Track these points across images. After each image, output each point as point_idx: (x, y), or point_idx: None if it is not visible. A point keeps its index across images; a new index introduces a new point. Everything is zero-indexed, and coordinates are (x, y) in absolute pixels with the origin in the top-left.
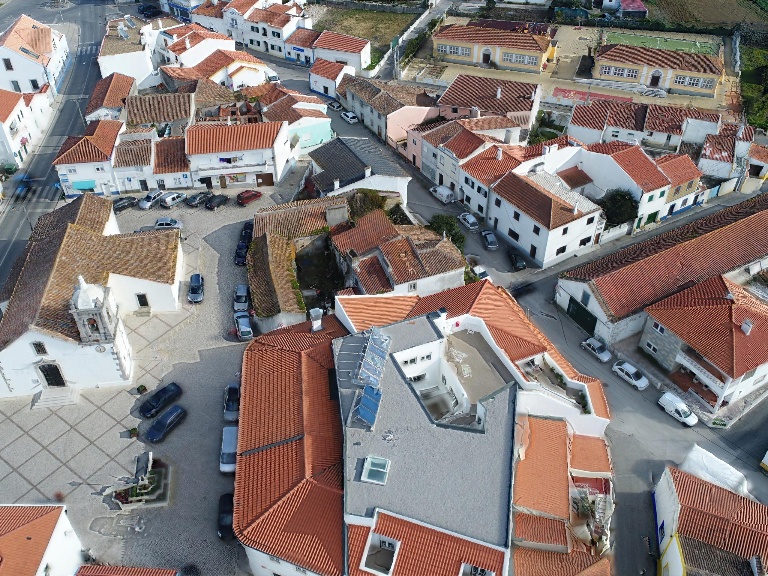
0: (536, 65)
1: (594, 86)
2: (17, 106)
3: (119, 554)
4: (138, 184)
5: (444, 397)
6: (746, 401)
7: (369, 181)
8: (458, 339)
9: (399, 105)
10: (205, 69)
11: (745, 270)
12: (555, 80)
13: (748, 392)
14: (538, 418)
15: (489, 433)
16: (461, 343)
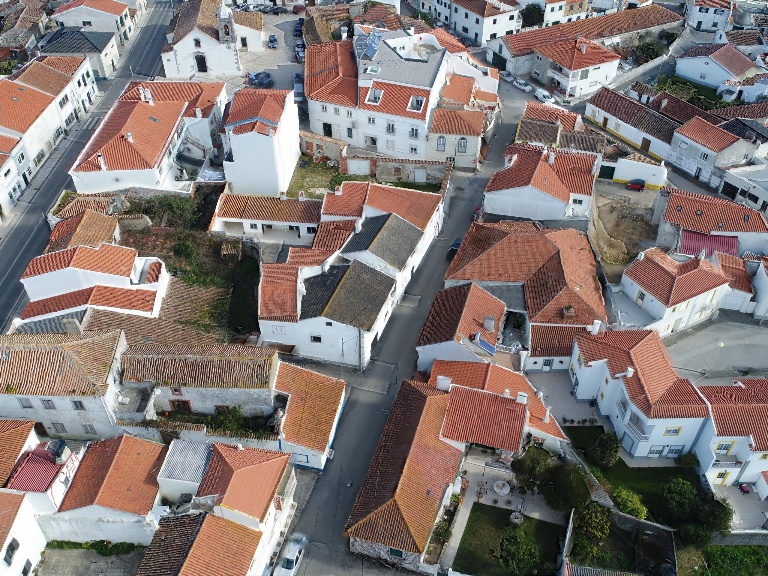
0: None
1: None
2: None
3: None
4: (231, 0)
5: None
6: (586, 96)
7: None
8: (421, 47)
9: None
10: None
11: (602, 43)
12: None
13: (588, 92)
14: (460, 76)
15: (430, 62)
16: None
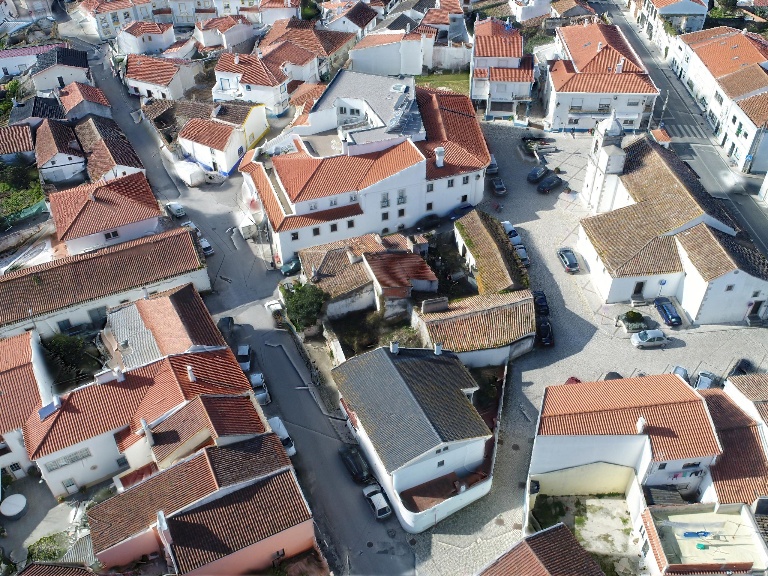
0: None
1: None
2: None
3: None
4: None
5: None
6: None
7: None
8: None
9: None
10: None
11: None
12: None
13: None
14: None
15: None
16: None
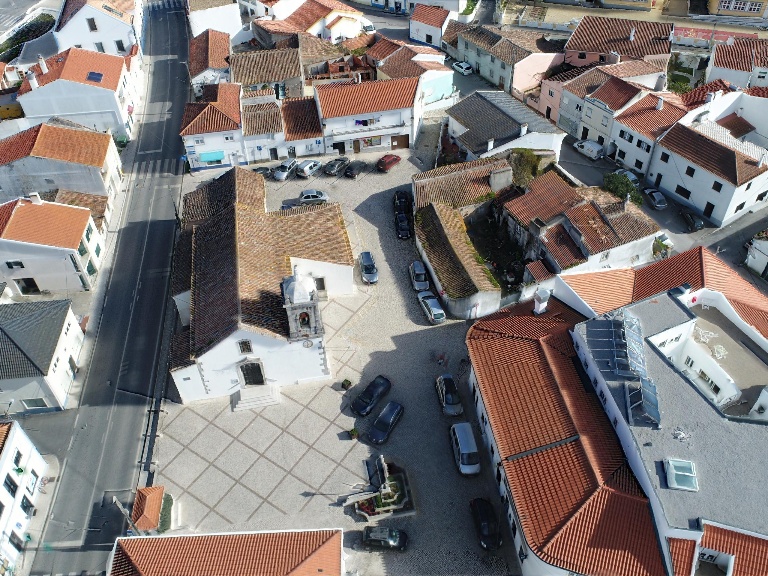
0: (646, 2)
1: (712, 22)
2: (122, 71)
3: (382, 572)
4: (268, 153)
5: (700, 382)
6: None
7: (525, 140)
8: None
9: (525, 53)
10: (299, 21)
11: None
12: (668, 17)
13: None
14: None
15: None
16: (699, 320)
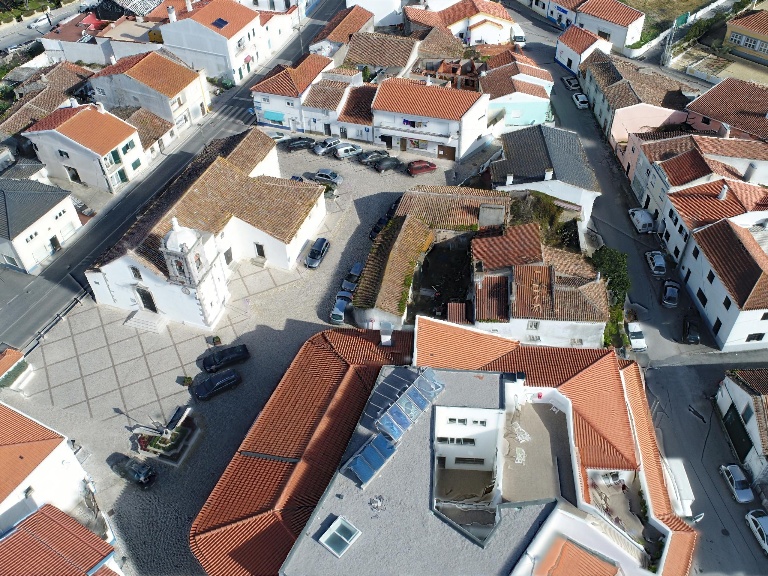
0: None
1: None
2: (249, 24)
3: (115, 496)
4: (322, 127)
5: (482, 476)
6: None
7: (547, 185)
8: (535, 412)
9: (635, 100)
10: (448, 16)
11: None
12: None
13: None
14: (582, 549)
15: (488, 550)
16: (536, 419)
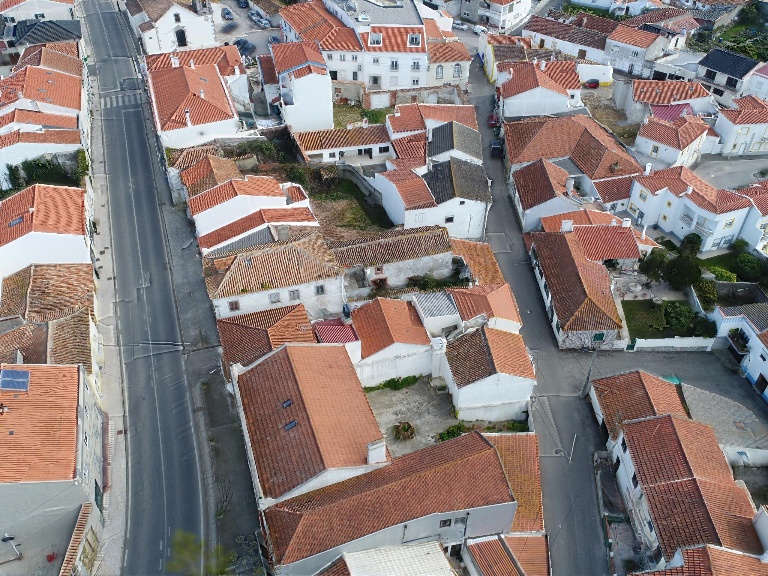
0: None
1: None
2: None
3: None
4: None
5: None
6: (513, 27)
7: None
8: None
9: None
10: None
11: None
12: None
13: (513, 24)
14: (422, 18)
15: (405, 7)
16: None
